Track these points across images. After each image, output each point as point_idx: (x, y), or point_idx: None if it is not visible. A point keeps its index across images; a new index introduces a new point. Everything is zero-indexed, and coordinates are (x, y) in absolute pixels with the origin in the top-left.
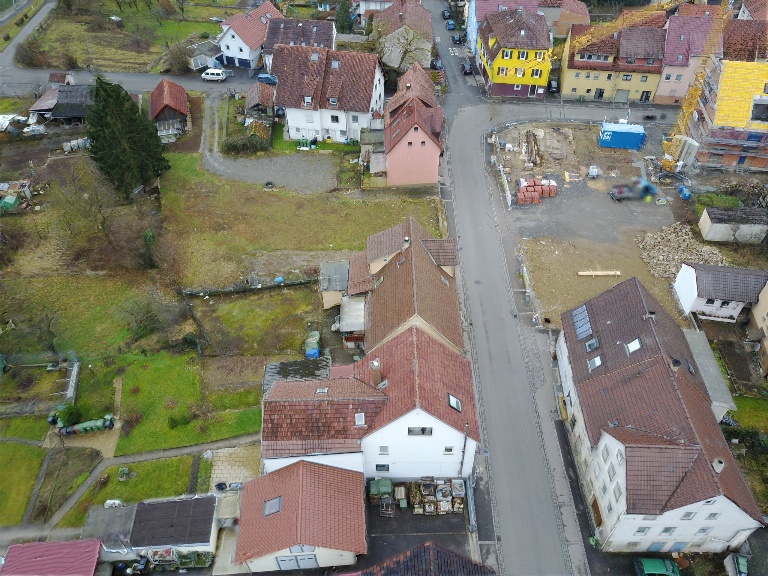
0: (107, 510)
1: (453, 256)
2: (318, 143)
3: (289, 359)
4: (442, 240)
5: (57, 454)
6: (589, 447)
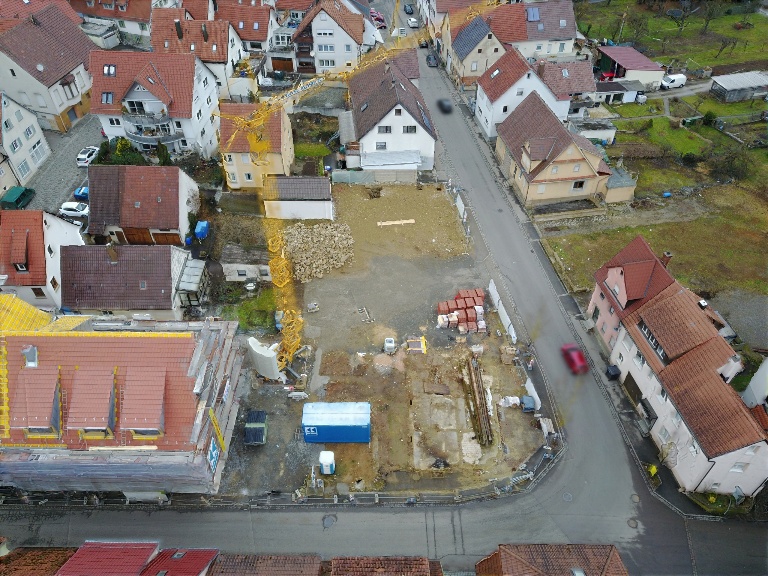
0: (640, 89)
1: None
2: None
3: (611, 154)
4: None
5: (697, 114)
6: None
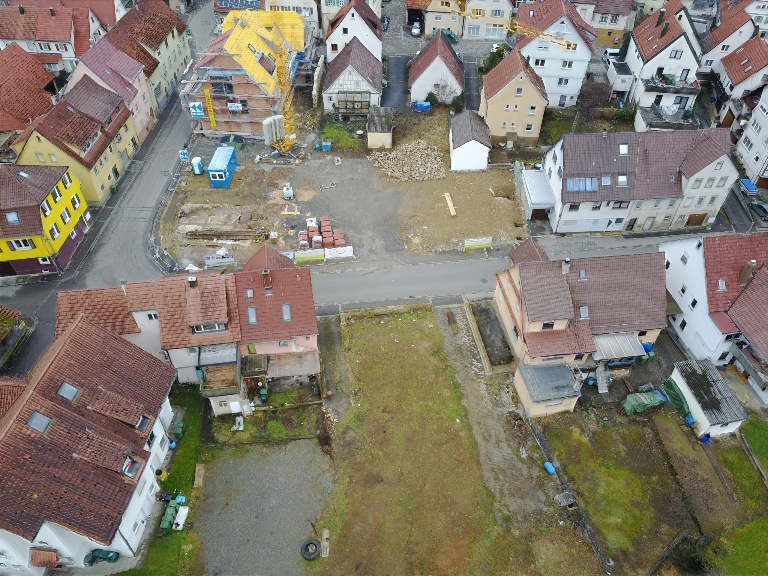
0: None
1: (541, 249)
2: None
3: (664, 428)
4: (536, 247)
5: None
6: (669, 207)
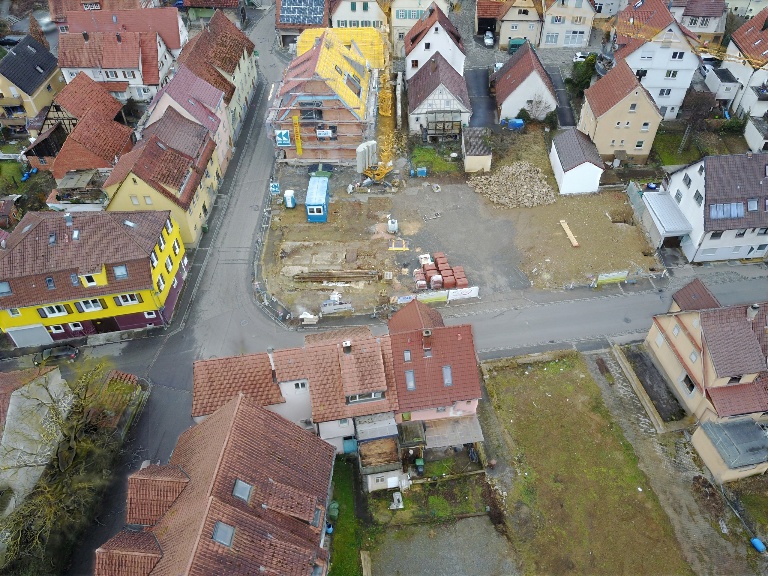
0: None
1: None
2: None
3: None
4: None
5: None
6: None
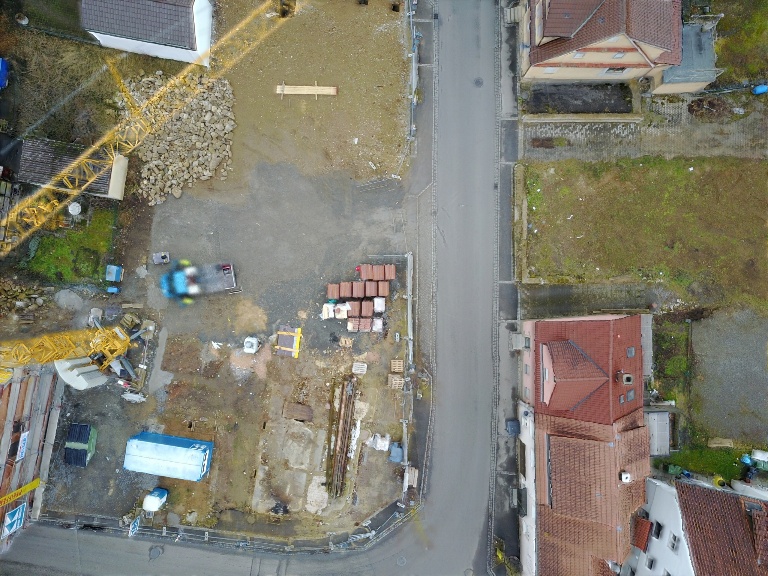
0: None
1: None
2: (738, 473)
3: None
4: None
5: None
6: None
